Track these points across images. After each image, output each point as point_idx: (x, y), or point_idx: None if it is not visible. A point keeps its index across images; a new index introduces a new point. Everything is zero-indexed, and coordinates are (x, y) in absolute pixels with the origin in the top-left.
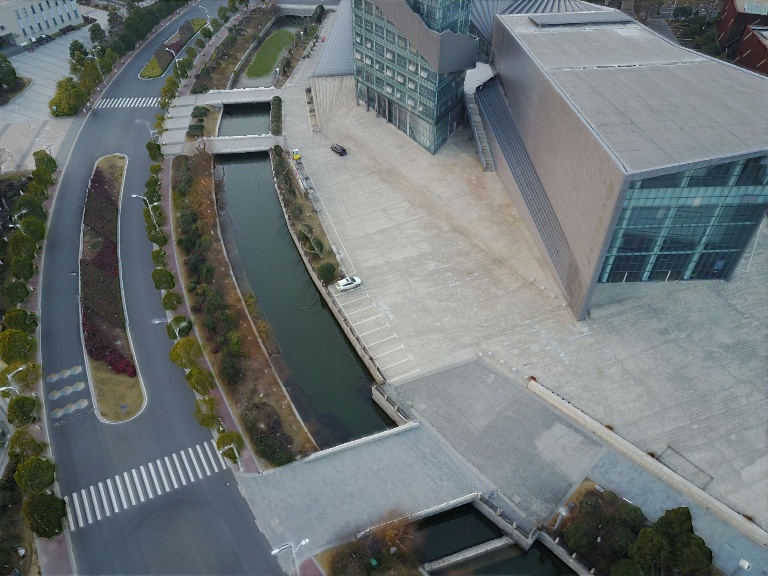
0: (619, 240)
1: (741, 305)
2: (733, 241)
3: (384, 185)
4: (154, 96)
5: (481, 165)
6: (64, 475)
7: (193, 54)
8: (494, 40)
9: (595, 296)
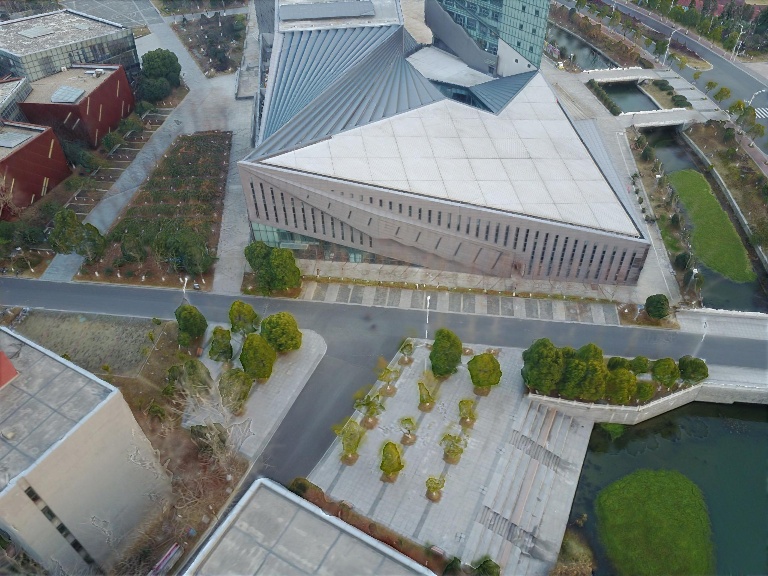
0: None
1: None
2: None
3: None
4: None
5: None
6: None
7: None
8: None
9: None
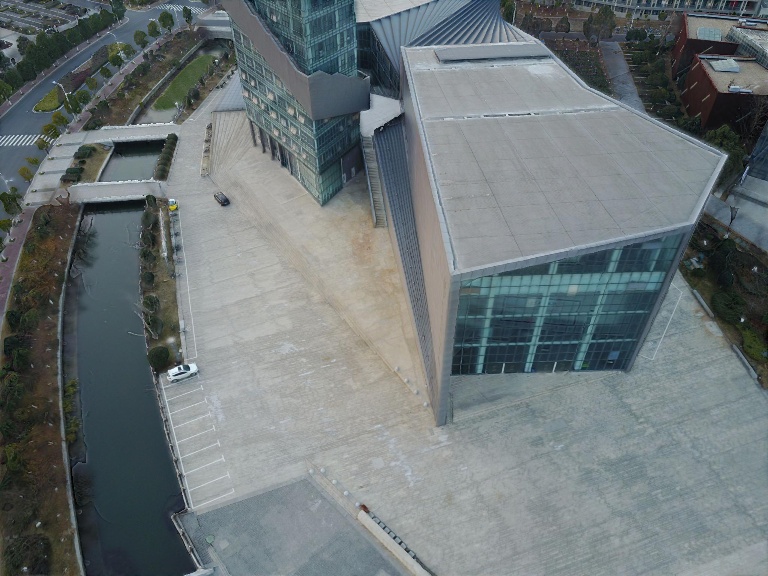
0: (486, 330)
1: (637, 405)
2: (625, 331)
3: (260, 243)
4: (42, 133)
5: (372, 220)
6: None
7: (93, 85)
8: (400, 75)
9: (465, 392)
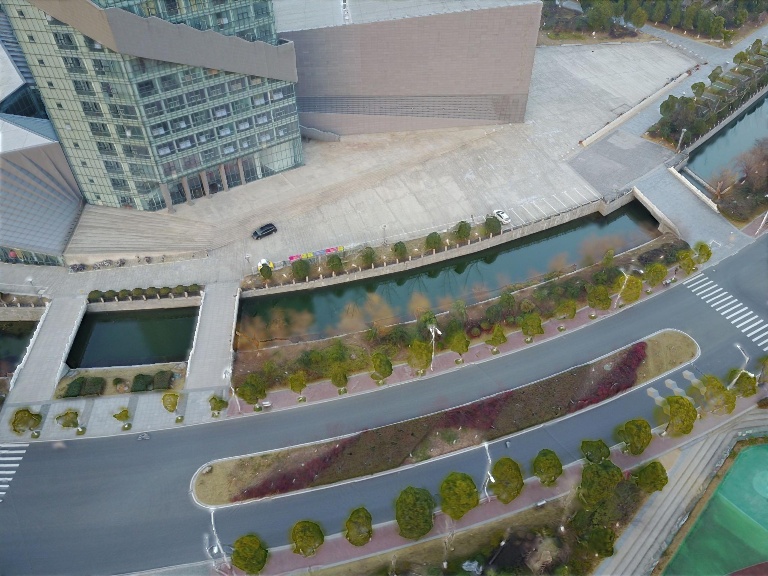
0: None
1: None
2: None
3: (344, 201)
4: None
5: (331, 141)
6: (759, 367)
7: None
8: None
9: None
